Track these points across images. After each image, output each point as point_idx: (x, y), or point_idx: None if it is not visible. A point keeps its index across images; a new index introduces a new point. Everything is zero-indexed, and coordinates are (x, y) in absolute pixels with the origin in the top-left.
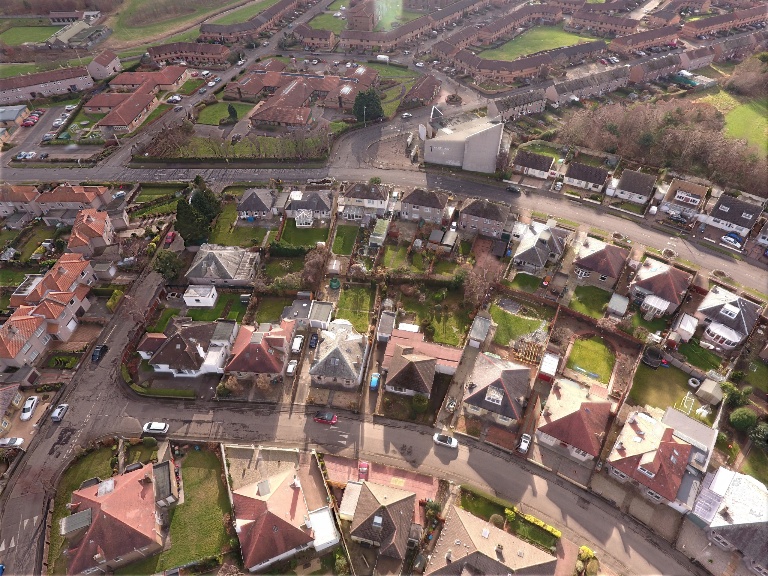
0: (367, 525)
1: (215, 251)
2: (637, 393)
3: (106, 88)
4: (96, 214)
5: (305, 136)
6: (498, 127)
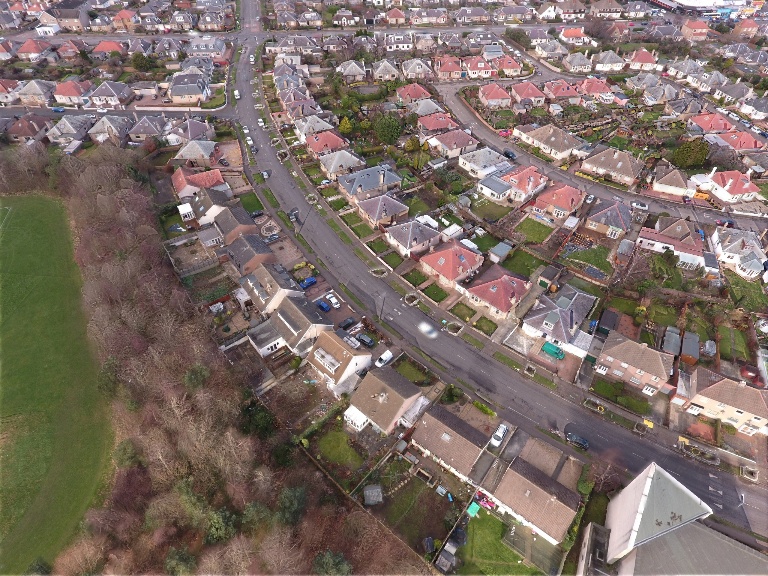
0: None
1: None
2: None
3: None
4: None
5: None
6: None
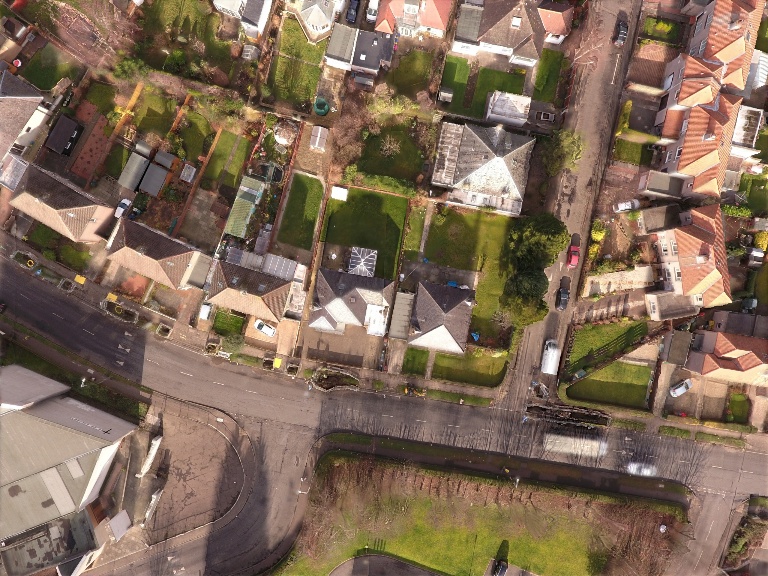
0: None
1: (495, 166)
2: None
3: None
4: (699, 278)
5: None
6: None
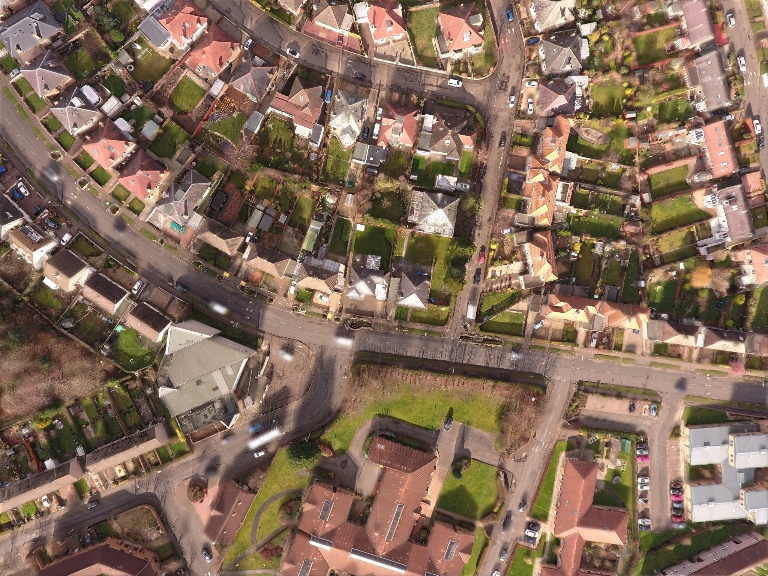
0: (339, 4)
1: (439, 213)
2: None
3: (621, 572)
4: (540, 267)
5: None
6: (176, 326)
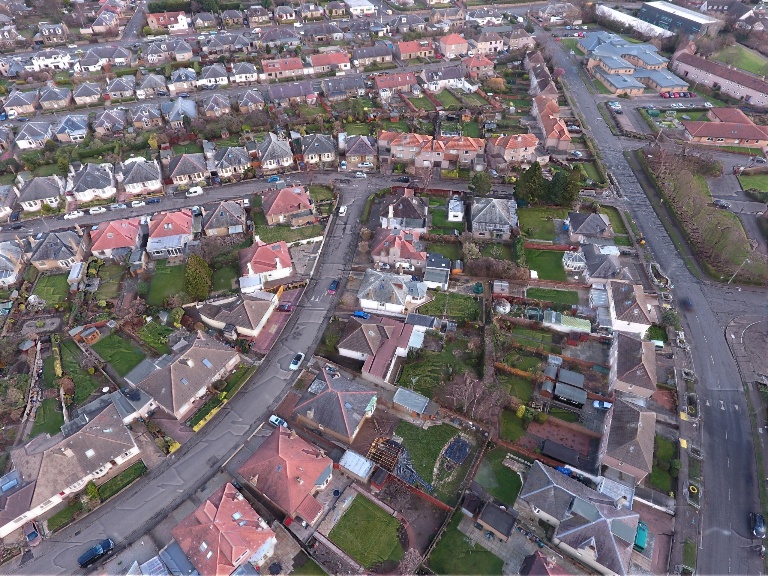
0: None
1: (497, 203)
2: (309, 575)
3: (763, 113)
4: (528, 140)
5: (748, 249)
6: None
